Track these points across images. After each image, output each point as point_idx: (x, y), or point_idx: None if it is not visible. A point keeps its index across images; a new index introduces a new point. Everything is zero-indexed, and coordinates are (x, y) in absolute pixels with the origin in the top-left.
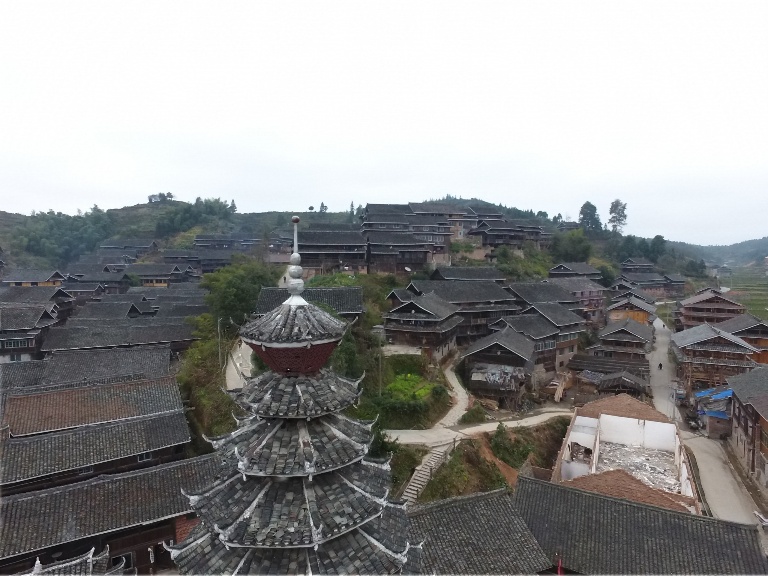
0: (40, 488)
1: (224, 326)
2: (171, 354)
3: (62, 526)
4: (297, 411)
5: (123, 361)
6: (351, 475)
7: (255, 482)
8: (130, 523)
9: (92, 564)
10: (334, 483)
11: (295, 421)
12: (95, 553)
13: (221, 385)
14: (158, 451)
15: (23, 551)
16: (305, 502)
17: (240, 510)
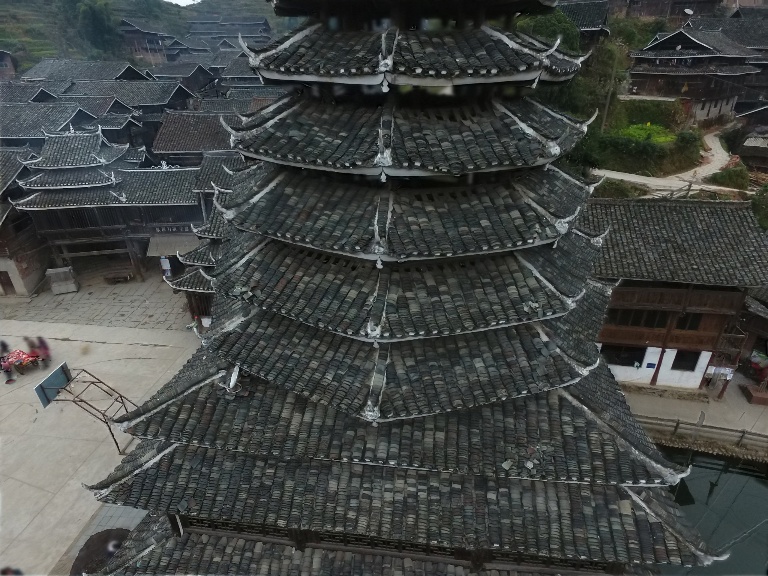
0: None
1: None
2: None
3: None
4: None
5: None
6: None
7: None
8: None
9: None
10: None
11: None
12: None
13: None
14: None
15: None
16: None
17: None
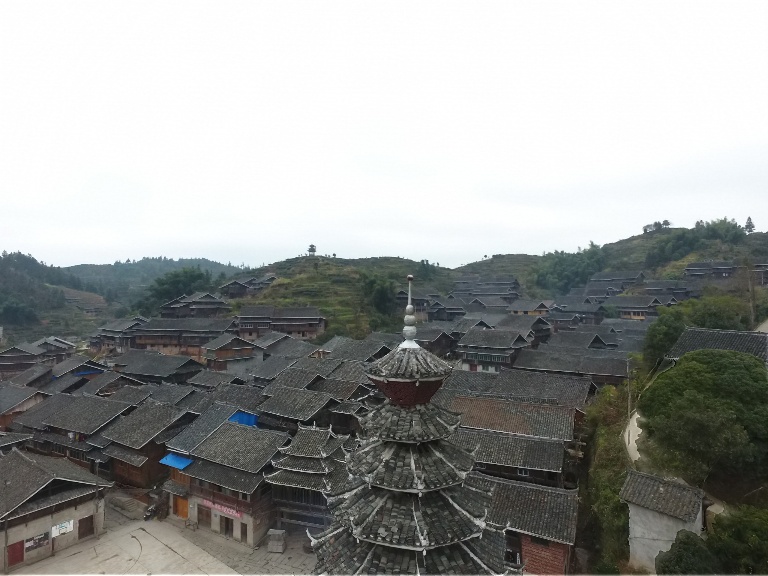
0: None
1: (633, 366)
2: (591, 387)
3: None
4: None
5: (548, 385)
6: (426, 508)
7: None
8: None
9: None
10: (404, 505)
11: None
12: None
13: (620, 429)
14: (532, 471)
15: None
16: None
17: (343, 490)
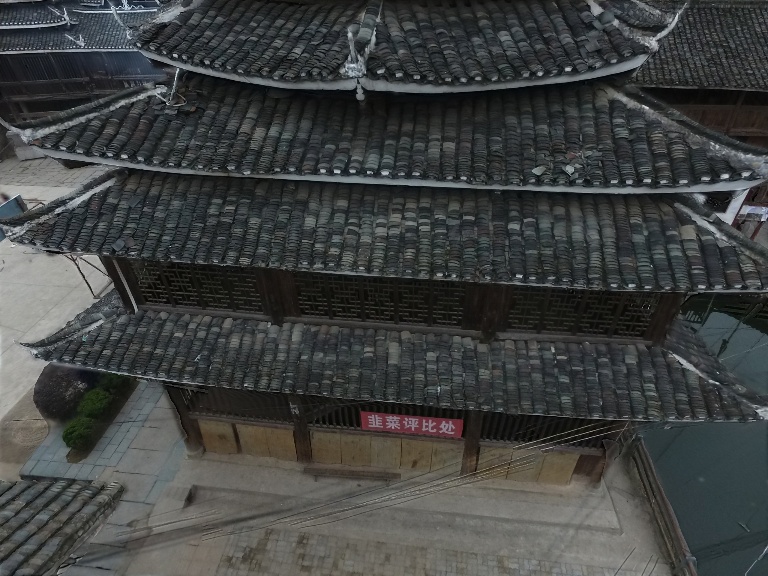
0: None
1: None
2: None
3: None
4: None
5: None
6: None
7: None
8: None
9: None
10: None
11: None
12: None
13: None
14: None
15: None
16: None
17: None
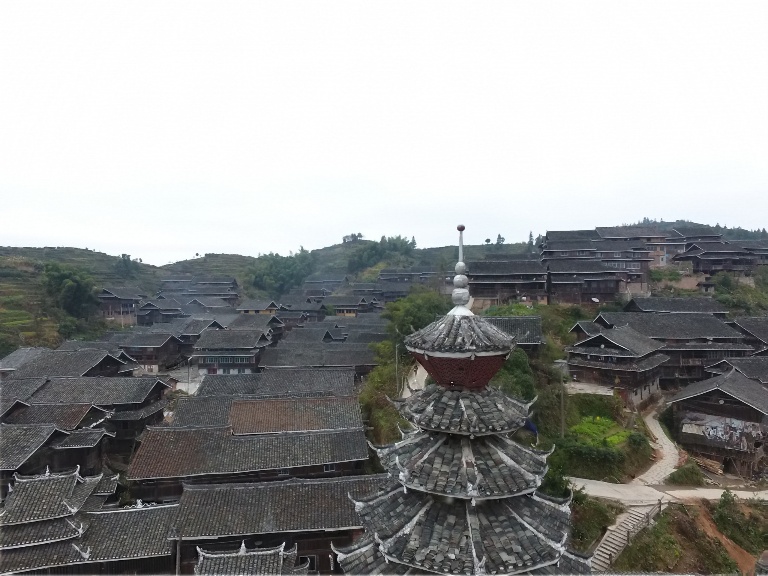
0: (250, 481)
1: (401, 352)
2: (355, 376)
3: (263, 518)
4: (460, 426)
5: (317, 379)
6: (521, 509)
7: (417, 498)
8: (315, 527)
9: (283, 557)
10: (501, 514)
11: (458, 439)
12: (287, 549)
13: None
14: (341, 464)
15: (234, 533)
16: (468, 529)
17: (400, 524)
